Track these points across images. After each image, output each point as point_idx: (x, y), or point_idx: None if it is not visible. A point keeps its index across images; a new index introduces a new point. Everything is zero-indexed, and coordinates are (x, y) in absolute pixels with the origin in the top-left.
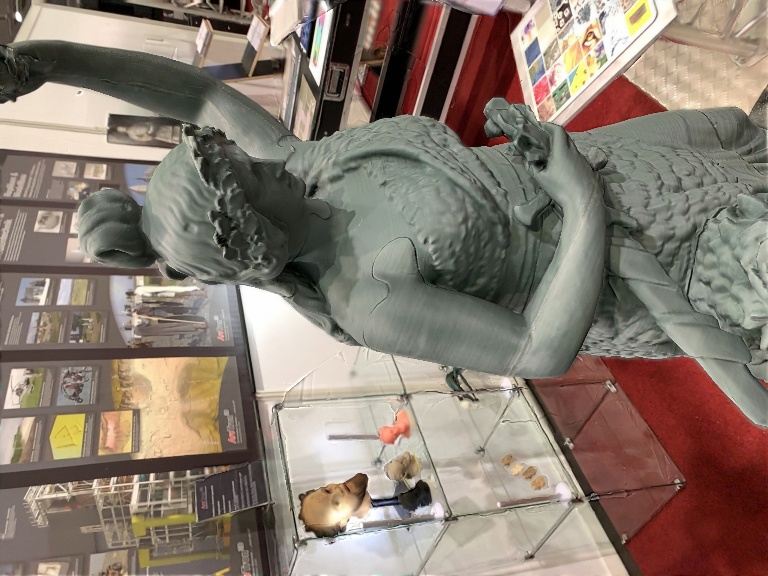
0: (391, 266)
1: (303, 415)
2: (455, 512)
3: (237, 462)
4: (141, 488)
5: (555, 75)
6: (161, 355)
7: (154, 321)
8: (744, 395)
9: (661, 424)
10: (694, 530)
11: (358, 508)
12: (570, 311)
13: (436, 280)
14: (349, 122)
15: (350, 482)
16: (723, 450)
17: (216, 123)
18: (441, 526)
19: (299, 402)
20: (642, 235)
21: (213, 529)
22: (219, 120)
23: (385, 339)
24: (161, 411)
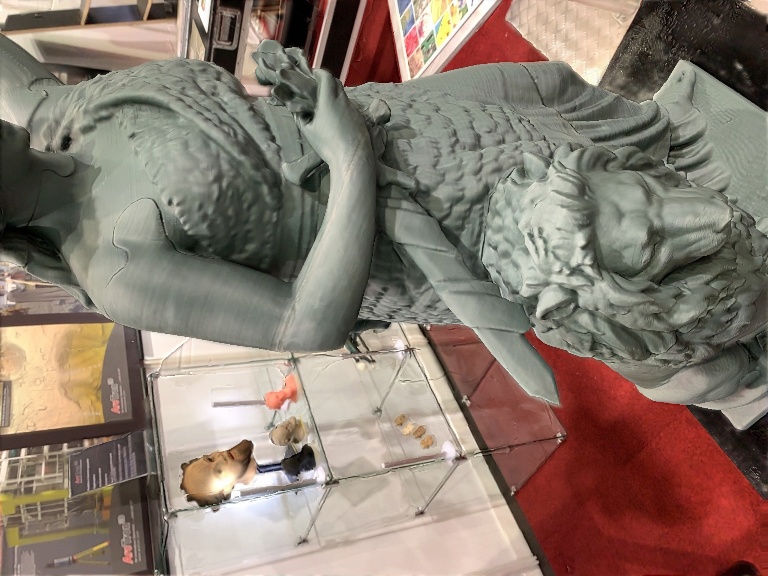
0: (133, 231)
1: (192, 382)
2: None
3: (120, 432)
4: (11, 464)
5: (423, 25)
6: (38, 322)
7: (31, 286)
8: (518, 366)
9: None
10: (573, 480)
11: (243, 475)
12: (333, 280)
13: (194, 246)
14: (244, 73)
15: (234, 449)
16: (599, 404)
17: None
18: (323, 490)
19: (177, 370)
20: (429, 196)
21: (91, 503)
22: None
23: (128, 314)
24: (36, 382)
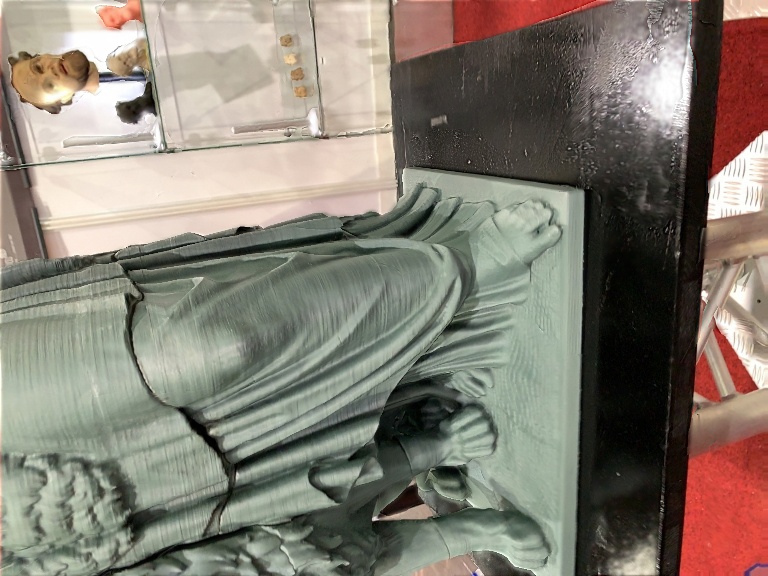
0: None
1: None
2: (172, 144)
3: None
4: None
5: None
6: None
7: None
8: None
9: None
10: None
11: (82, 88)
12: None
13: None
14: None
15: (67, 62)
16: None
17: None
18: None
19: None
20: None
21: None
22: None
23: None
24: None
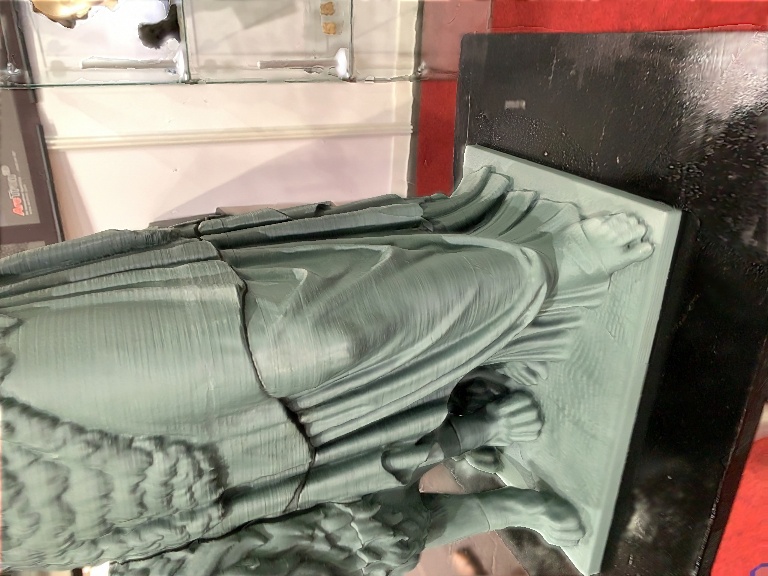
0: None
1: None
2: (196, 75)
3: None
4: None
5: None
6: None
7: None
8: None
9: (502, 8)
10: None
11: (100, 3)
12: None
13: None
14: None
15: None
16: None
17: None
18: None
19: None
20: None
21: None
22: None
23: None
24: None
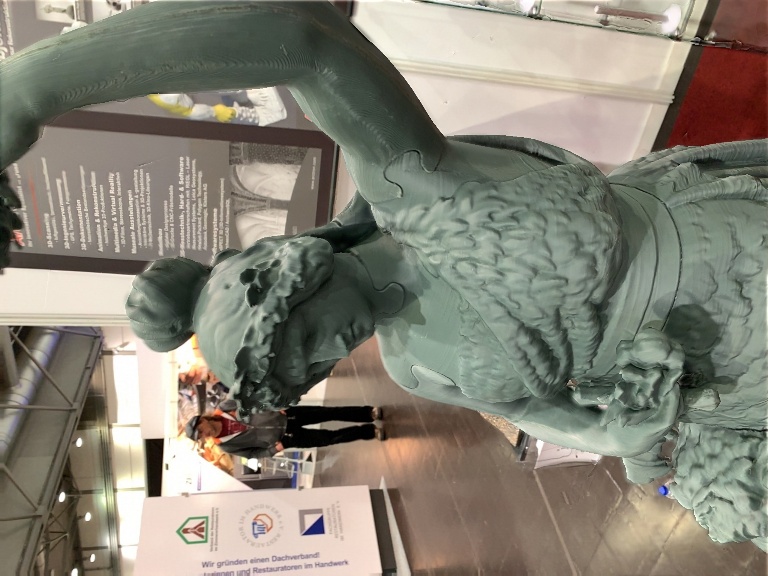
0: (429, 377)
1: None
2: (544, 11)
3: None
4: None
5: None
6: None
7: None
8: None
9: None
10: (761, 92)
11: None
12: None
13: None
14: None
15: None
16: None
17: (304, 110)
18: None
19: None
20: None
21: None
22: (308, 113)
23: None
24: None
